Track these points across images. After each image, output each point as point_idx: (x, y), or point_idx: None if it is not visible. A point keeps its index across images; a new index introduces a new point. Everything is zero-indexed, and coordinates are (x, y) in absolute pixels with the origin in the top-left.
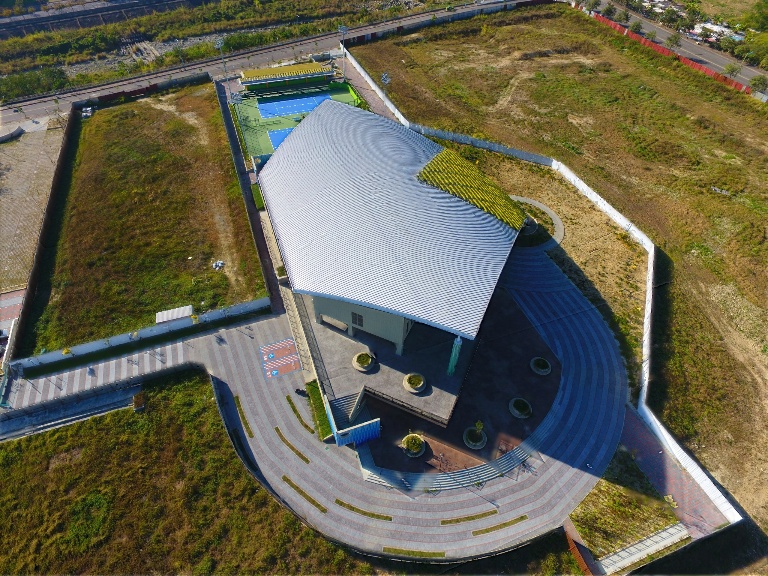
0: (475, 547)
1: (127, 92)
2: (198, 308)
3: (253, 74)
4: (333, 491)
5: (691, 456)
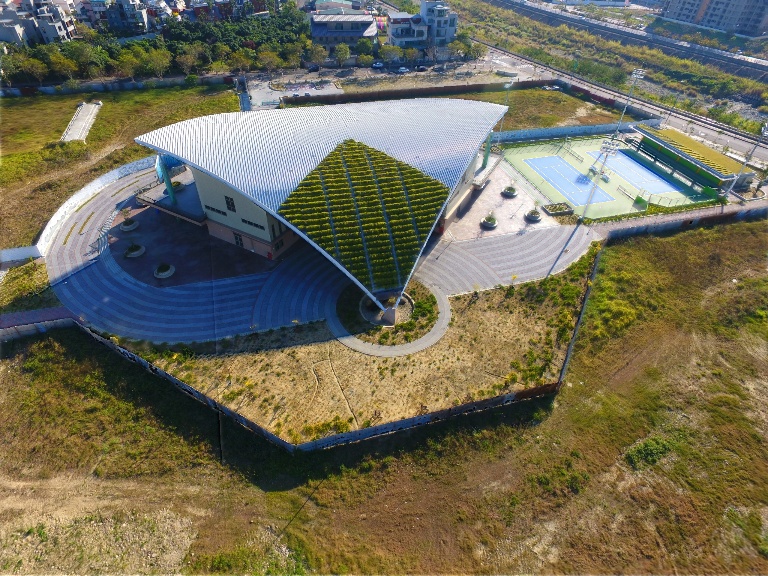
0: (69, 222)
1: (592, 93)
2: None
3: (670, 133)
4: (145, 180)
5: (11, 354)
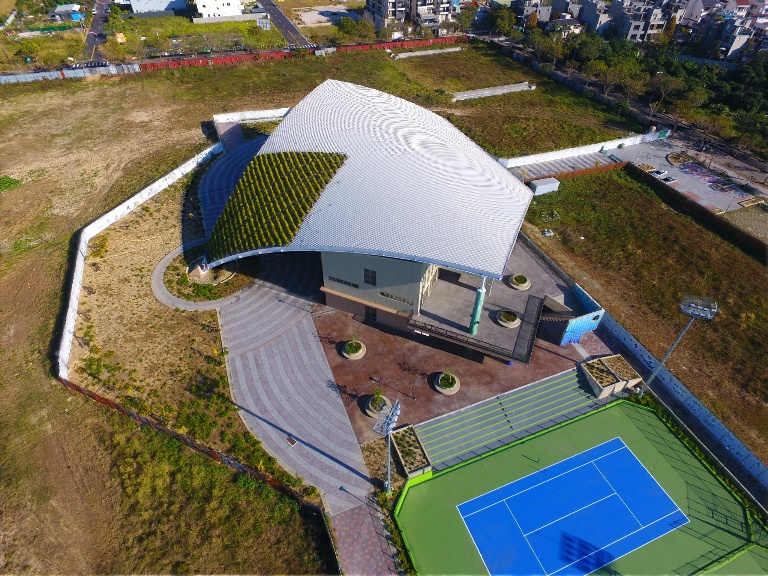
0: None
1: None
2: (534, 196)
3: None
4: None
5: None
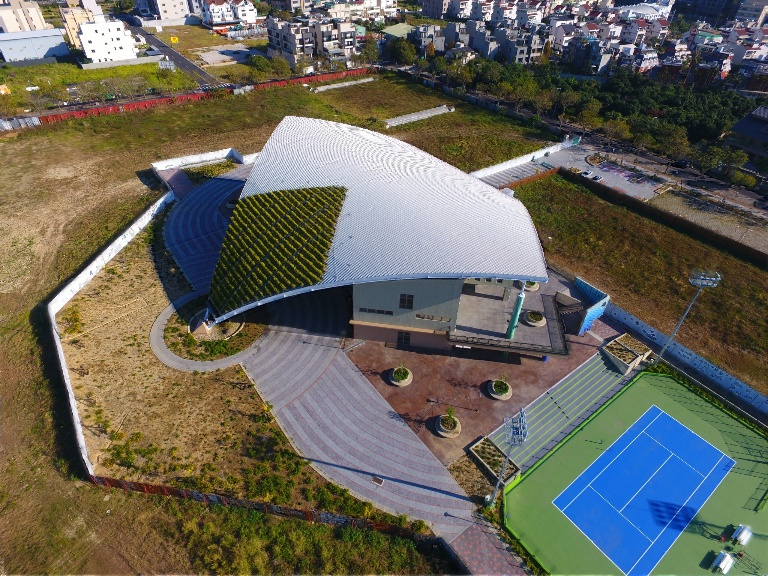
0: None
1: None
2: None
3: None
4: None
5: None
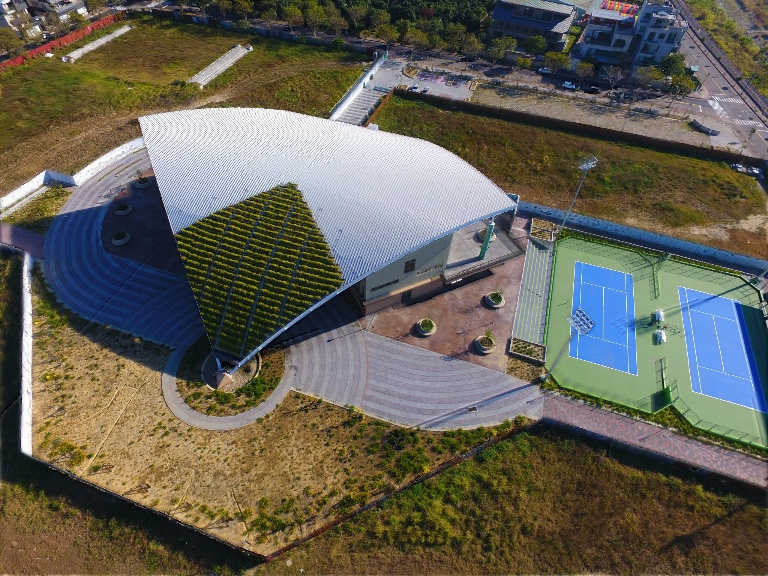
0: (119, 161)
1: None
2: None
3: None
4: None
5: None
